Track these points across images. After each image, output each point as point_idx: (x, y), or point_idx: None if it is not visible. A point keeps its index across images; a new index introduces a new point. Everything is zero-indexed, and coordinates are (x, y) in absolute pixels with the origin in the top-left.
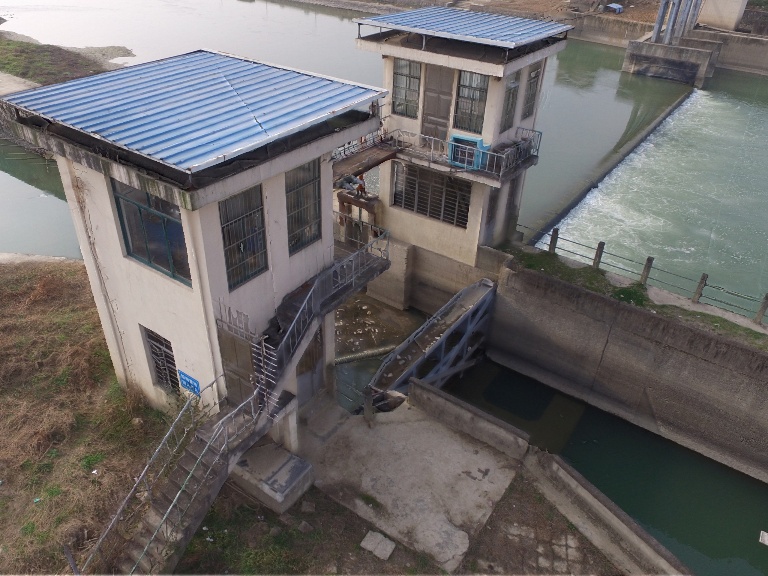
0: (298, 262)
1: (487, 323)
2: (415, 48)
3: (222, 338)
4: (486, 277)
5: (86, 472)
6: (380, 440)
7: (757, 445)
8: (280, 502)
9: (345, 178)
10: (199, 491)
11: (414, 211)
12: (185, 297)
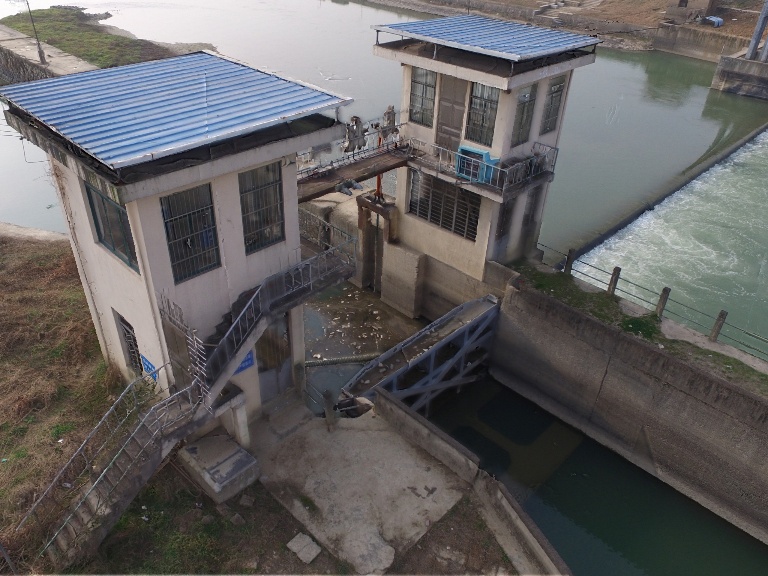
0: (257, 261)
1: (491, 340)
2: (431, 57)
3: (165, 328)
4: (492, 293)
5: (53, 440)
6: (335, 445)
7: (758, 502)
8: (217, 492)
9: (345, 182)
10: (131, 471)
11: (427, 220)
12: (137, 285)
